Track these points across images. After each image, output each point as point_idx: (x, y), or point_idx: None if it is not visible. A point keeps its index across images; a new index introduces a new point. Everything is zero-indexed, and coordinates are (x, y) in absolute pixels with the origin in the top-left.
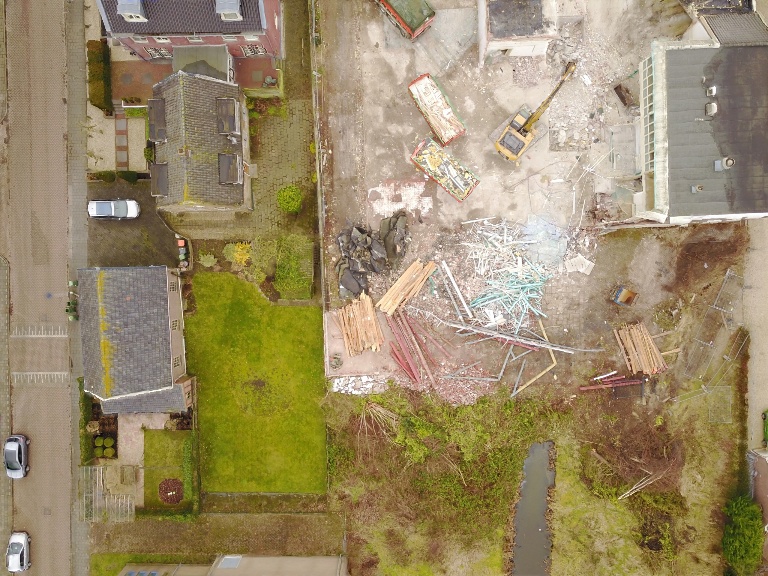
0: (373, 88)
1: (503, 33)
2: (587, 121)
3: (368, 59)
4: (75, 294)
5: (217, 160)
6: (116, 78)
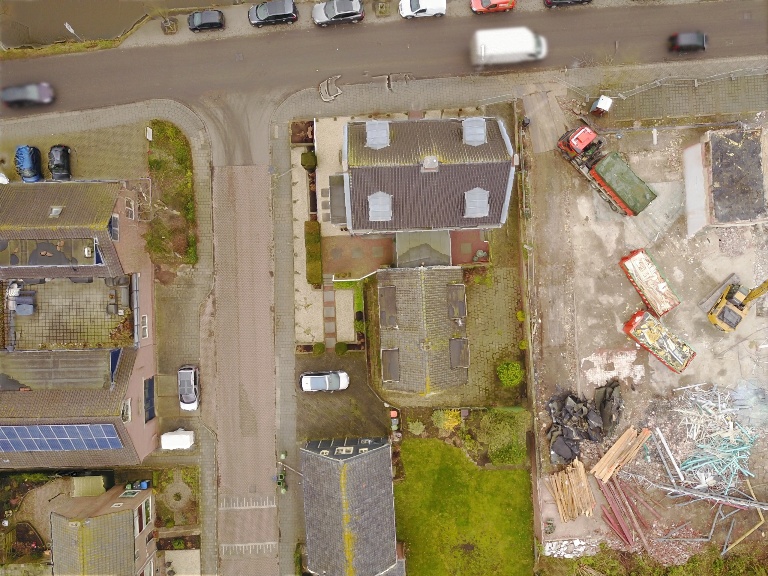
0: (584, 260)
1: (728, 218)
2: None
3: (578, 232)
4: (284, 465)
5: (449, 345)
6: (326, 253)
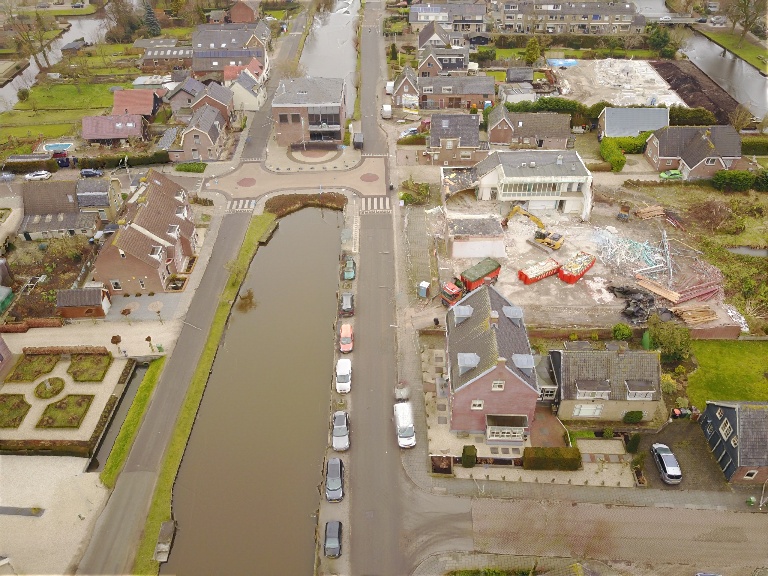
0: (529, 300)
1: (500, 230)
2: None
3: None
4: None
5: None
6: None
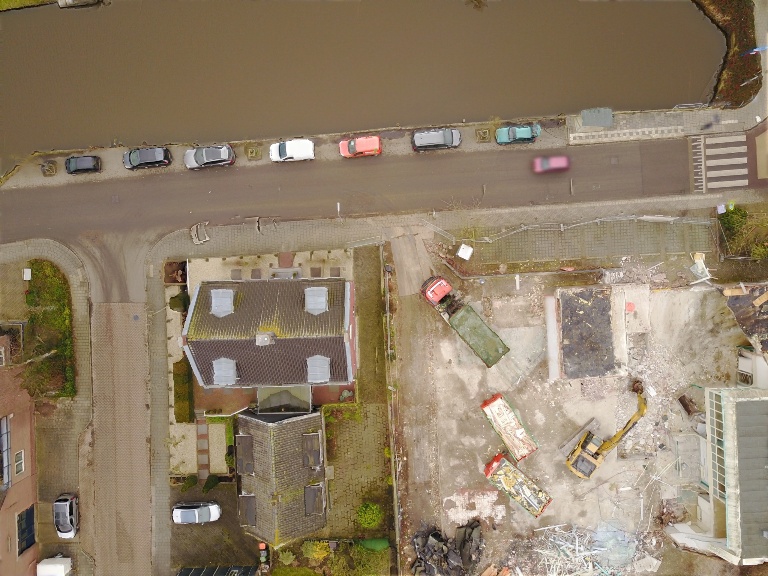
0: (447, 402)
1: (577, 374)
2: (652, 428)
3: (442, 375)
4: None
5: (303, 493)
6: (198, 389)
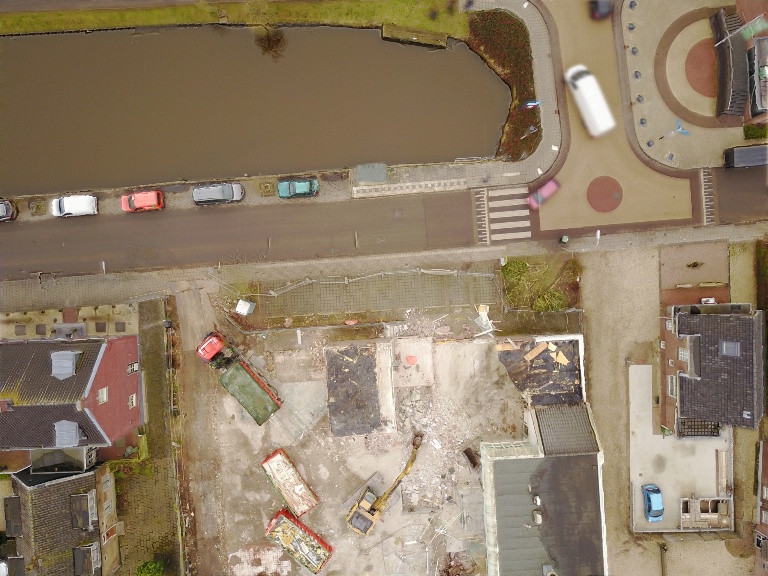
0: (230, 458)
1: (343, 432)
2: (439, 480)
3: (225, 430)
4: None
5: (72, 555)
6: None
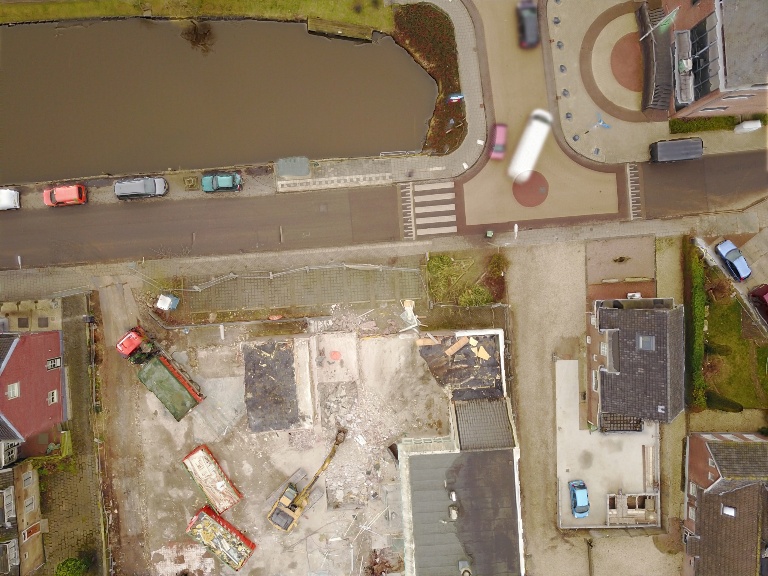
0: (153, 454)
1: (260, 428)
2: (365, 477)
3: (148, 426)
4: None
5: None
6: None
